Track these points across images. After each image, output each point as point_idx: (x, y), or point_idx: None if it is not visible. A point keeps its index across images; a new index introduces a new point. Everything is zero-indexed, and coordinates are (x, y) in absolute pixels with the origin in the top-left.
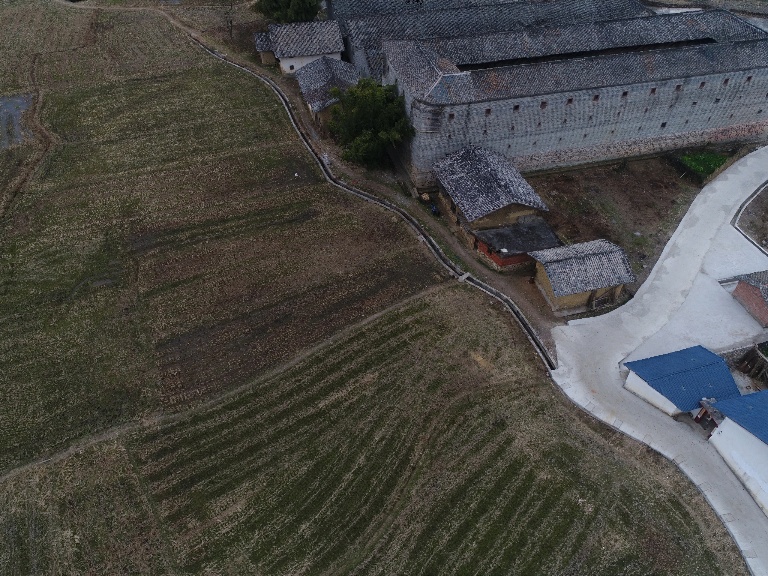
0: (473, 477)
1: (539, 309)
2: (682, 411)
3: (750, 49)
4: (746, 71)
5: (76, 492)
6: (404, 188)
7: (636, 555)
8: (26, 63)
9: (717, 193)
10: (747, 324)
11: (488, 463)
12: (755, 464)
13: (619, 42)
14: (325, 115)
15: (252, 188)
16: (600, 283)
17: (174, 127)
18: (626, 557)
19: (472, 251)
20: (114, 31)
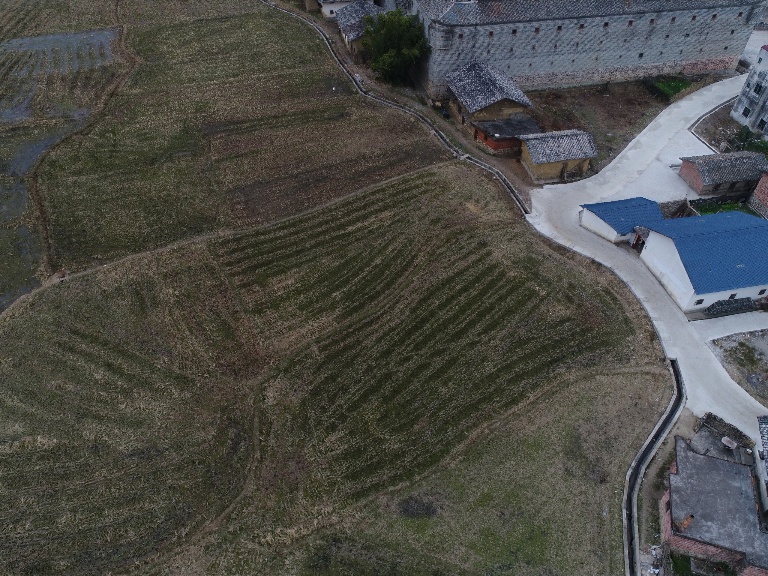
0: (460, 272)
1: (522, 178)
2: (622, 239)
3: None
4: (711, 9)
5: (174, 269)
6: (421, 100)
7: (573, 318)
8: (110, 6)
9: (681, 109)
10: (686, 193)
11: (471, 265)
12: (666, 262)
13: None
14: (359, 44)
15: (298, 97)
16: (569, 156)
17: (234, 54)
18: (566, 319)
19: (473, 141)
20: None
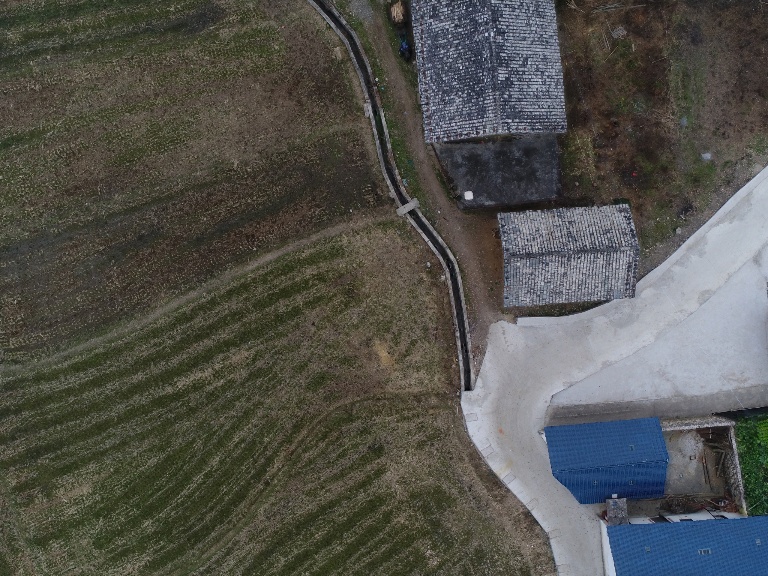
0: (327, 506)
1: (490, 286)
2: None
3: None
4: None
5: None
6: None
7: None
8: None
9: None
10: (756, 365)
11: (348, 494)
12: None
13: None
14: None
15: None
16: (577, 295)
17: None
18: None
19: None
20: None
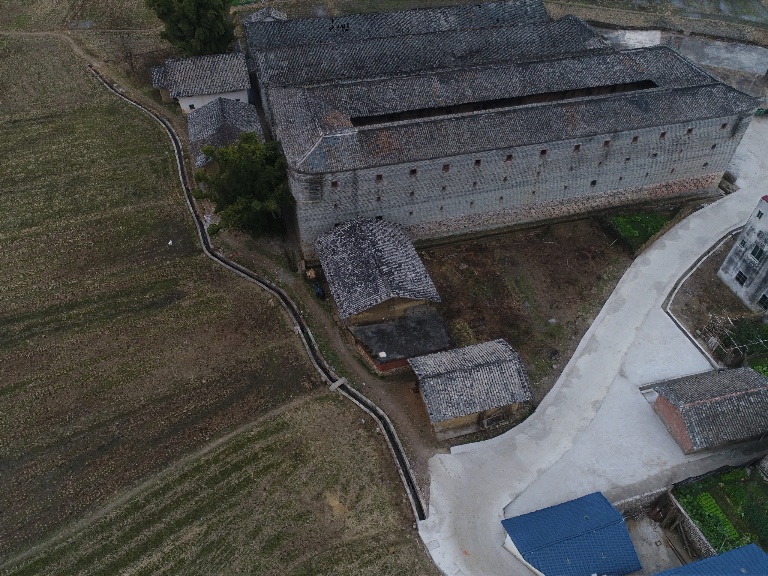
0: None
1: (419, 429)
2: None
3: (690, 97)
4: (685, 123)
5: None
6: (292, 260)
7: None
8: None
9: (651, 266)
10: (666, 449)
11: None
12: None
13: (544, 87)
14: (211, 170)
15: (115, 261)
16: (488, 403)
17: (44, 182)
18: None
19: (354, 347)
20: (7, 61)
